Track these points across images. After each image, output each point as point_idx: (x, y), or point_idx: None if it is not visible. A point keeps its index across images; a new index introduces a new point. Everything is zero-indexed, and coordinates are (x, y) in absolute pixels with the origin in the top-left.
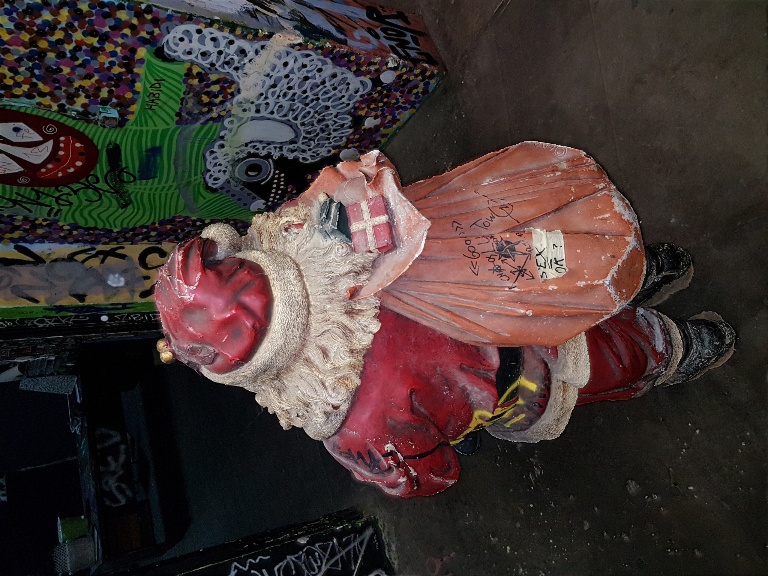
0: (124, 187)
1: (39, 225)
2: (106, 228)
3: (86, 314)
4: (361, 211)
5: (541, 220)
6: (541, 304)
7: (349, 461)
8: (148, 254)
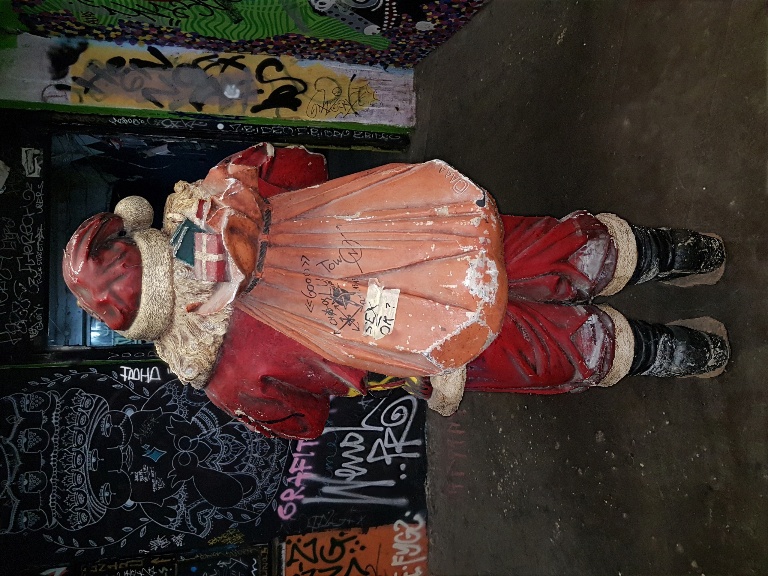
0: (232, 5)
1: (165, 31)
2: (225, 38)
3: (205, 120)
4: (202, 243)
5: (388, 273)
6: (366, 351)
7: None
8: (266, 66)
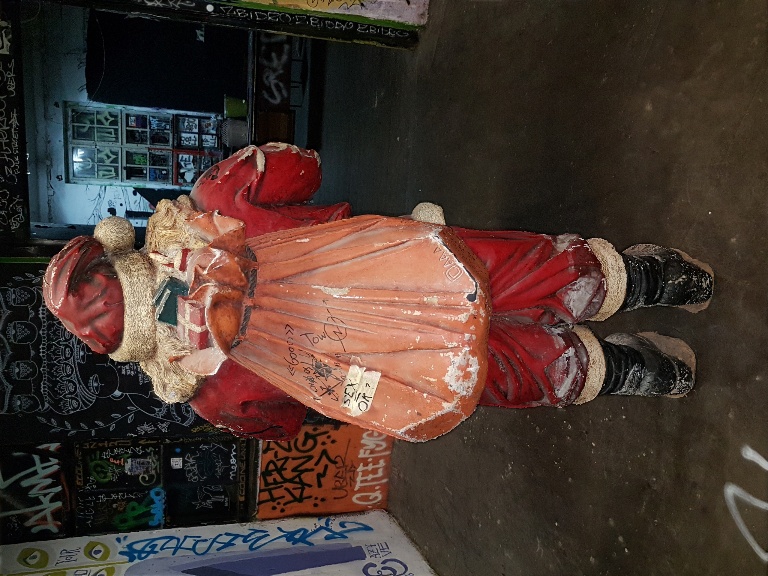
0: None
1: None
2: None
3: None
4: (184, 310)
5: (371, 355)
6: (343, 415)
7: None
8: None
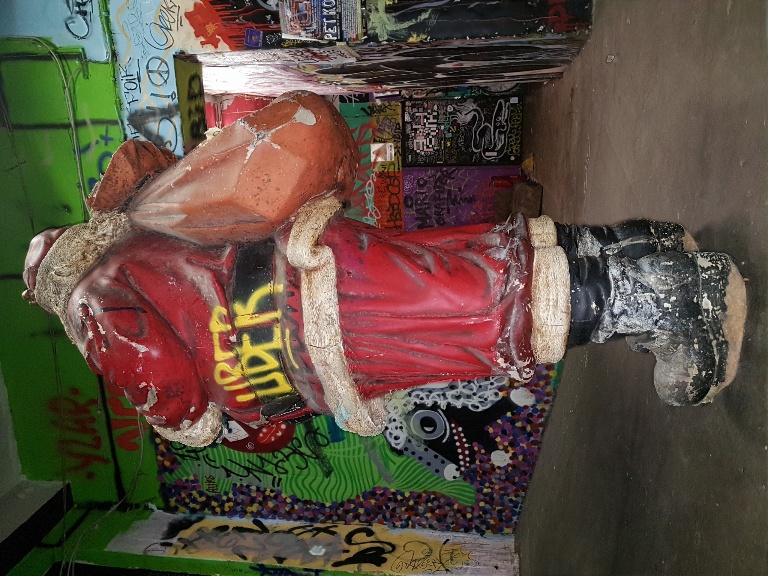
0: (323, 452)
1: (269, 497)
2: (319, 502)
3: None
4: None
5: None
6: None
7: (75, 338)
8: (357, 533)
